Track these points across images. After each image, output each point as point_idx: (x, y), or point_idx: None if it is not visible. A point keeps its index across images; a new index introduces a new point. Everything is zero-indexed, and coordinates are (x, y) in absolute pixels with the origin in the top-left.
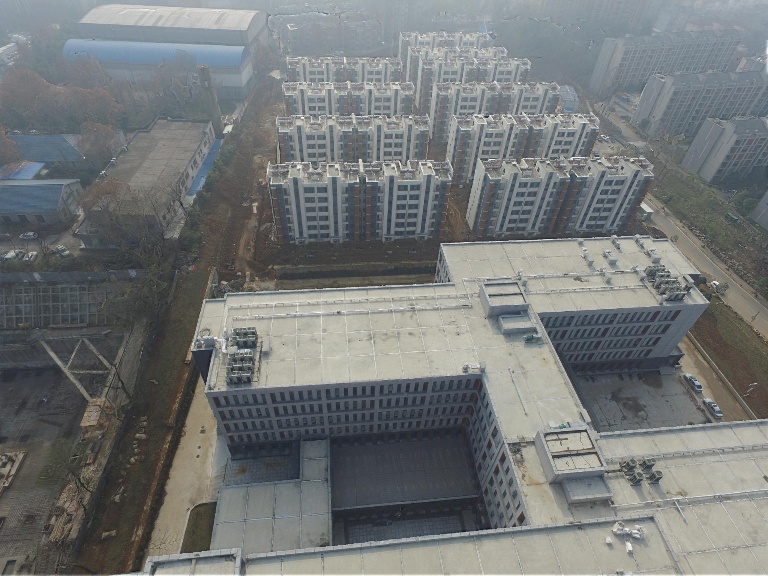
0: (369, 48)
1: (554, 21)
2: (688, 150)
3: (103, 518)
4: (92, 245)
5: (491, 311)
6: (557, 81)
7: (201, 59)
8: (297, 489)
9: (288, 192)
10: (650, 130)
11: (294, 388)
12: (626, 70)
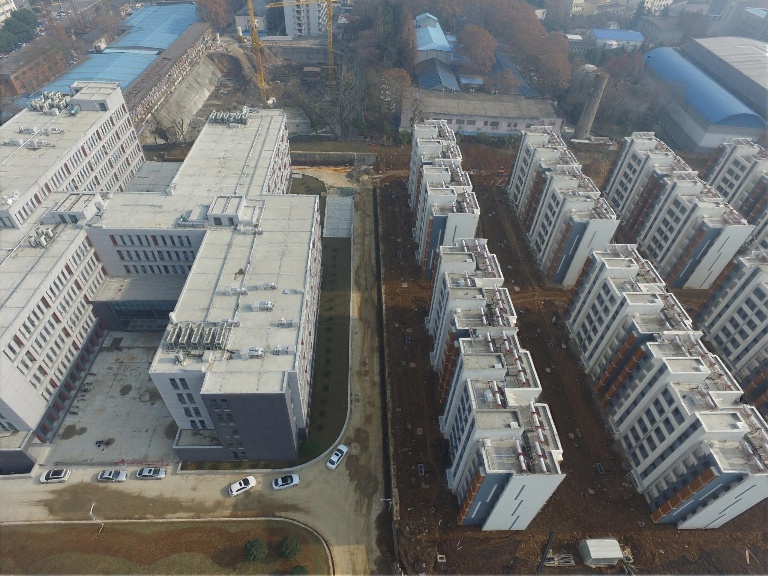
0: None
1: None
2: None
3: None
4: None
5: None
6: None
7: (700, 101)
8: None
9: None
10: None
11: None
12: None
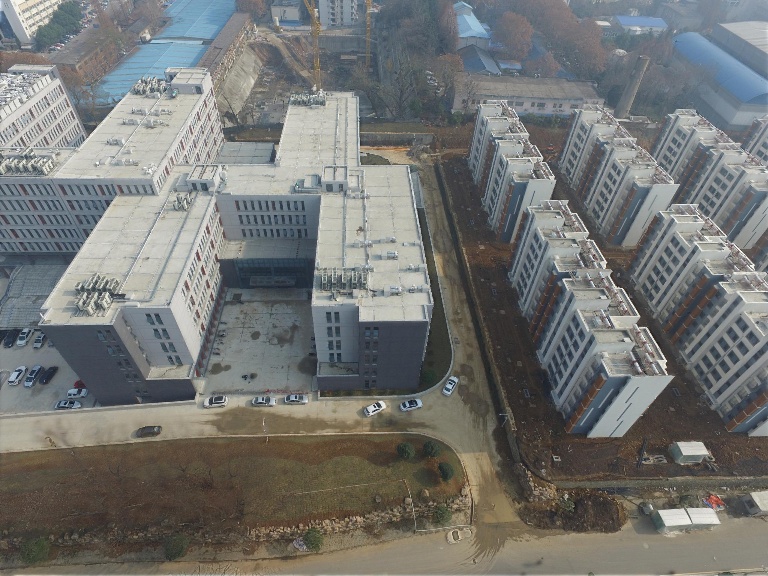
0: None
1: None
2: None
3: (278, 129)
4: None
5: None
6: None
7: (730, 82)
8: (265, 162)
9: None
10: None
11: None
12: None
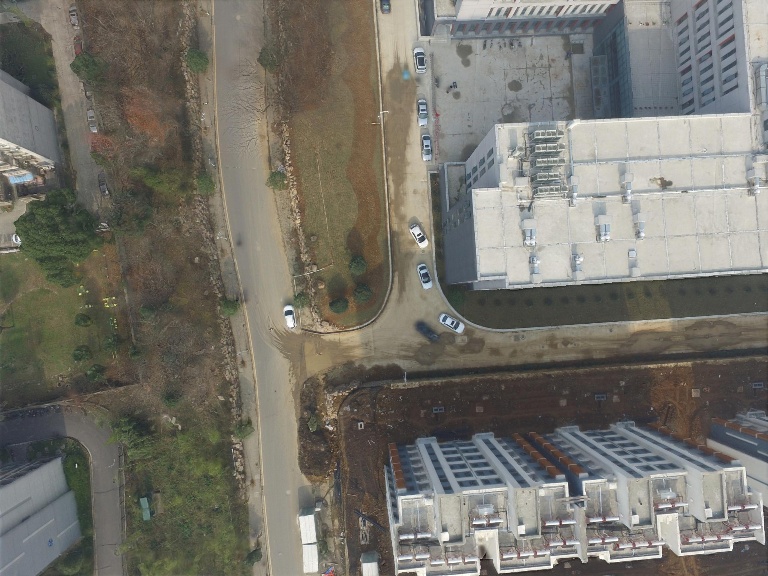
0: None
1: None
2: None
3: None
4: None
5: None
6: None
7: None
8: None
9: None
10: None
11: None
12: None
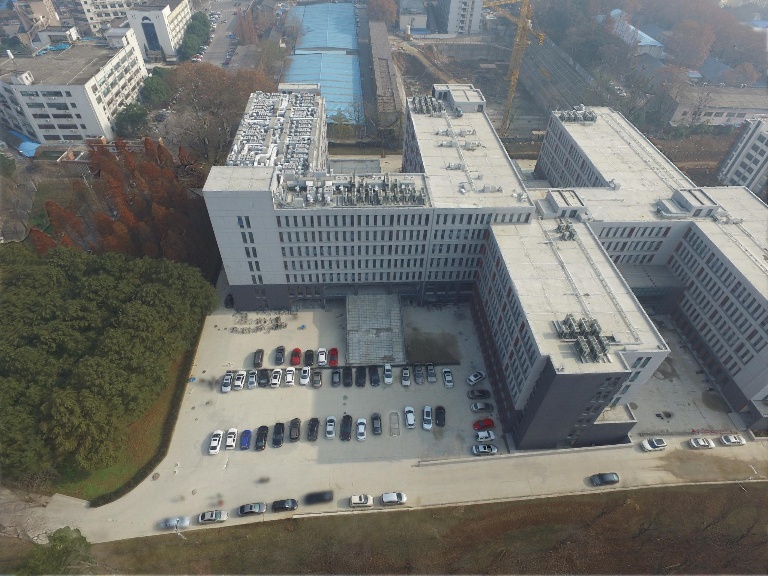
0: None
1: None
2: None
3: None
4: (646, 108)
5: (674, 195)
6: None
7: None
8: None
9: None
10: None
11: None
12: None
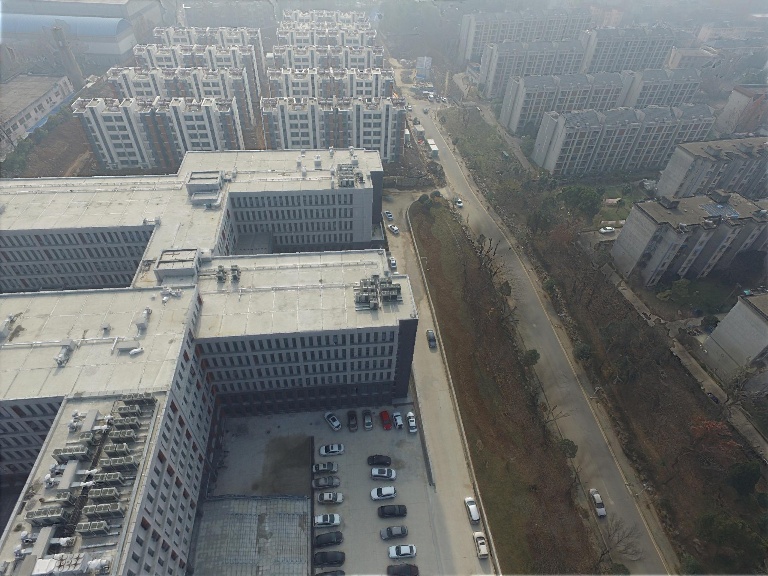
0: (262, 26)
1: (440, 3)
2: (502, 106)
3: None
4: None
5: (189, 189)
6: (425, 54)
7: (81, 29)
8: None
9: (91, 121)
10: (488, 93)
11: (7, 232)
12: (482, 43)
